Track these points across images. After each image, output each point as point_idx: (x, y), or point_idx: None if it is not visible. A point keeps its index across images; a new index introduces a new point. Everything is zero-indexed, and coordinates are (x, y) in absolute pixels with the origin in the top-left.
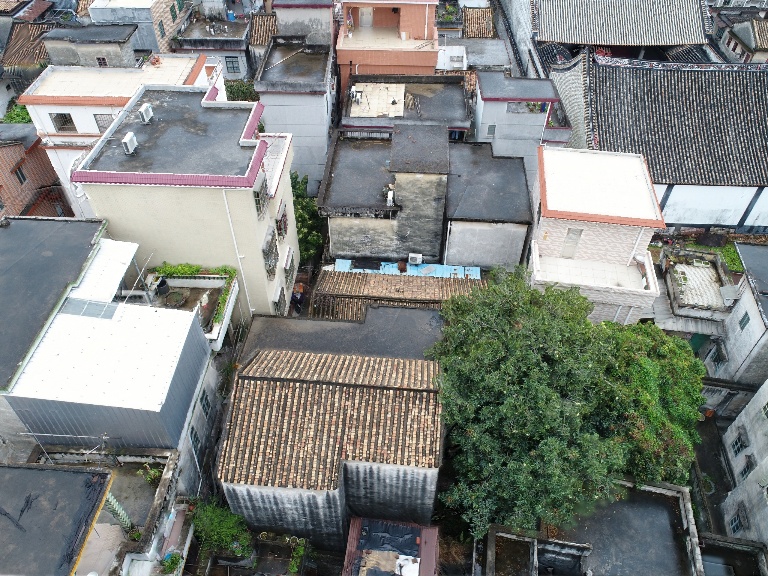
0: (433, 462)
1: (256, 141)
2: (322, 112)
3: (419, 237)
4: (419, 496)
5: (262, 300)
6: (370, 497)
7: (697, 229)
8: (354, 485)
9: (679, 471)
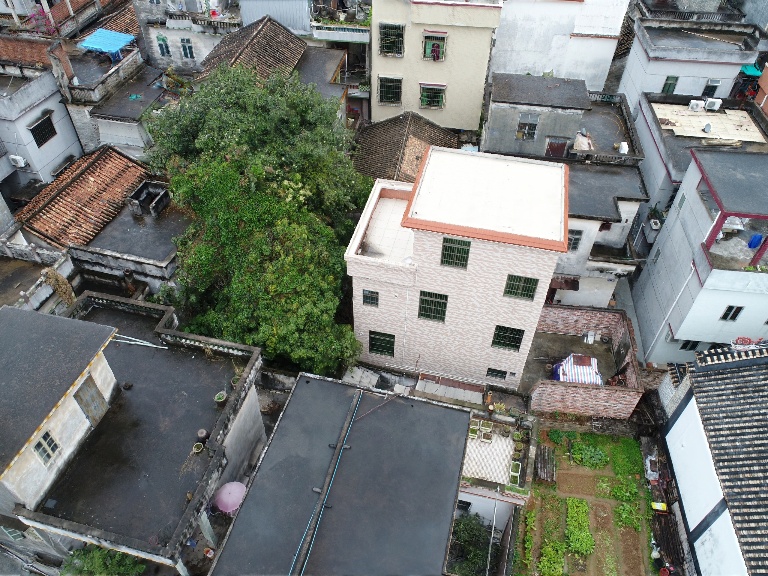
0: None
1: None
2: None
3: None
4: None
5: None
6: None
7: None
8: None
9: None
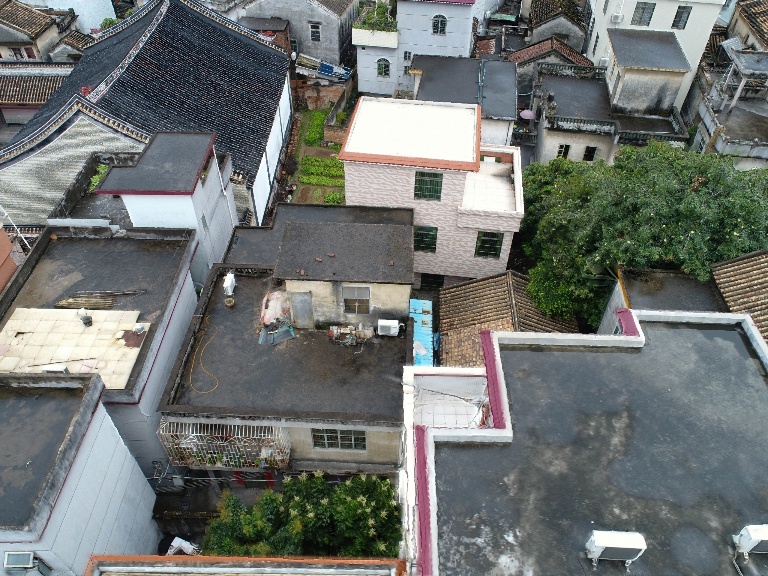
0: None
1: (636, 316)
2: (109, 424)
3: None
4: None
5: None
6: None
7: (279, 167)
8: None
9: None
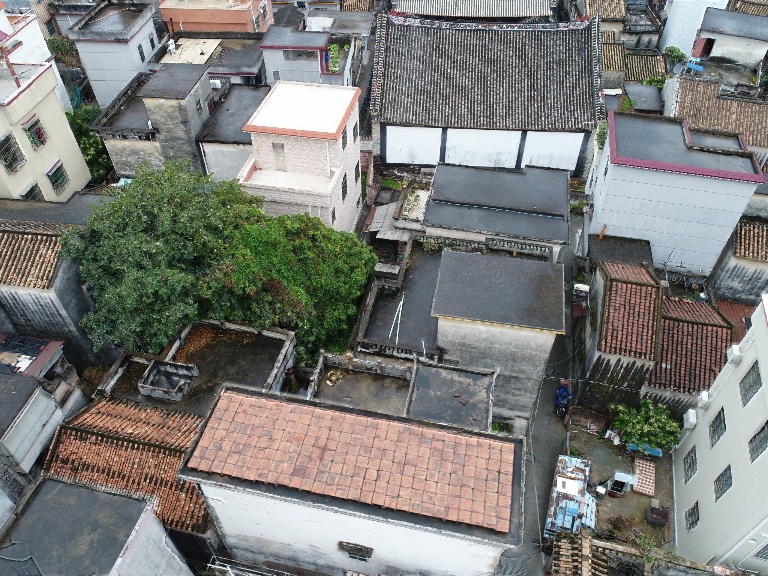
0: (46, 285)
1: None
2: (131, 58)
3: (182, 158)
4: (62, 323)
5: (6, 191)
6: (31, 325)
7: None
8: (12, 312)
9: (292, 320)
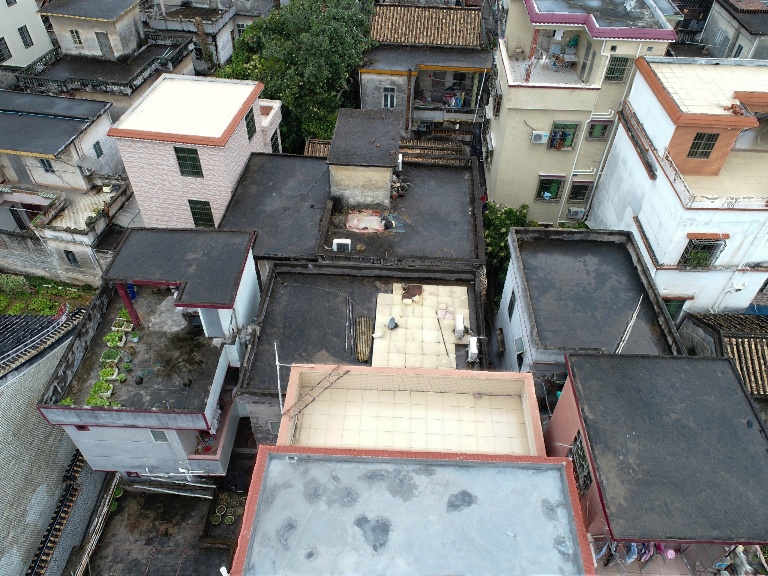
0: None
1: None
2: None
3: None
4: None
5: None
6: None
7: None
8: None
9: None
